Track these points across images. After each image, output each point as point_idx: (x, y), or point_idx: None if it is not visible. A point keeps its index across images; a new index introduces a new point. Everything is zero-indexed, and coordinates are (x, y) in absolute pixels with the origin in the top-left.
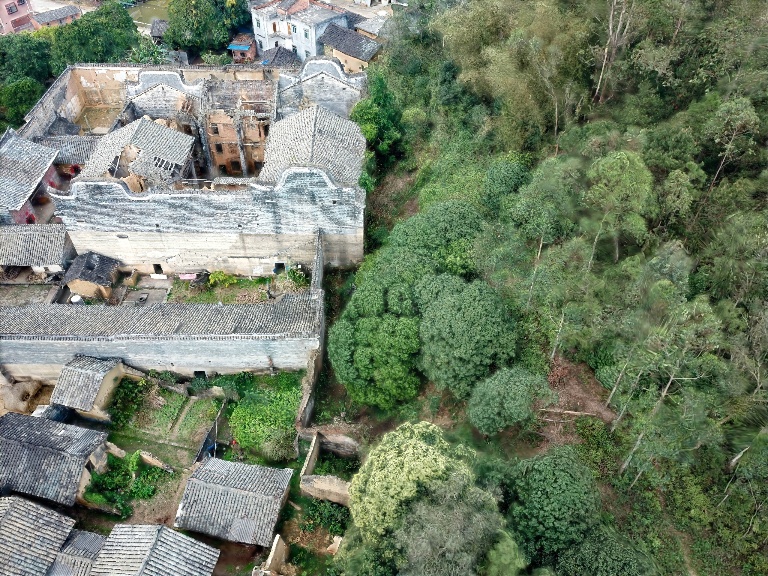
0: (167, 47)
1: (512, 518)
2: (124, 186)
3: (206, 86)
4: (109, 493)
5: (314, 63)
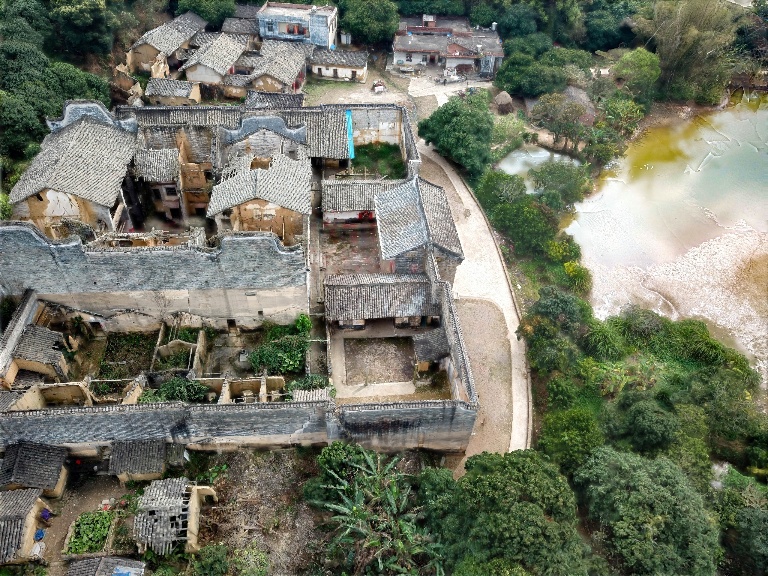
0: None
1: (47, 7)
2: None
3: None
4: None
5: None
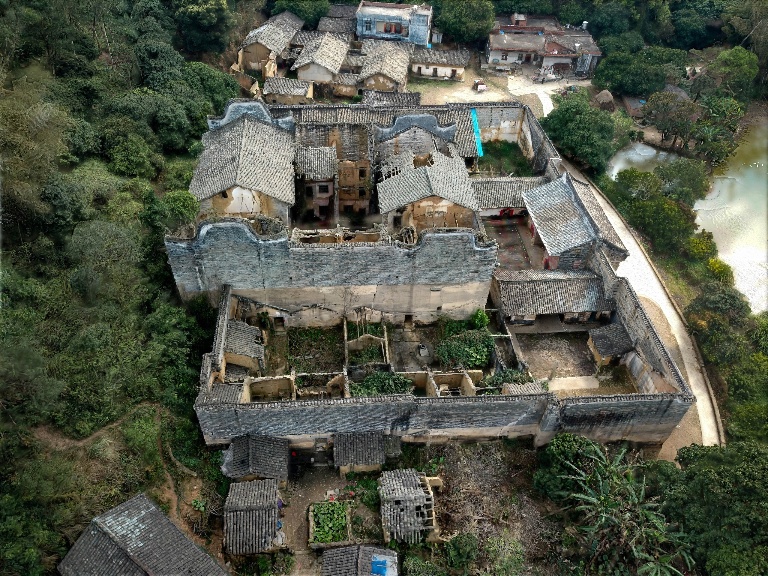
0: None
1: (169, 7)
2: None
3: None
4: None
5: None
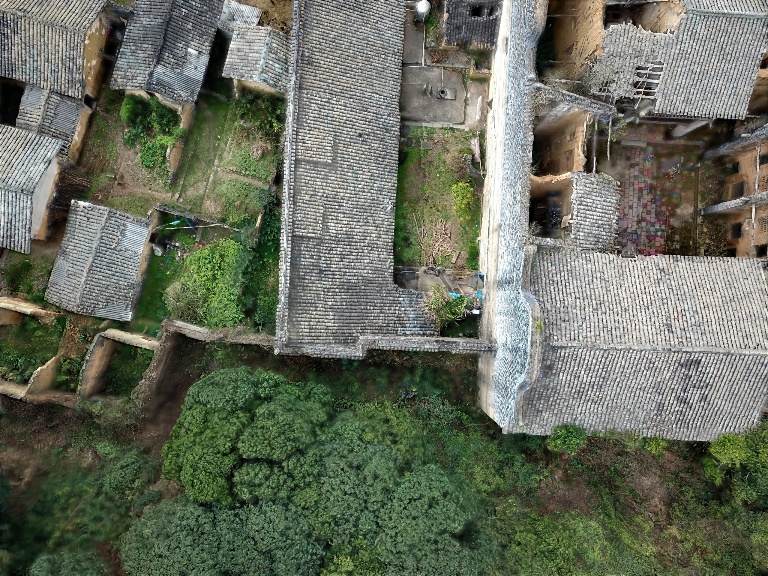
0: None
1: None
2: (535, 33)
3: None
4: (145, 120)
5: None
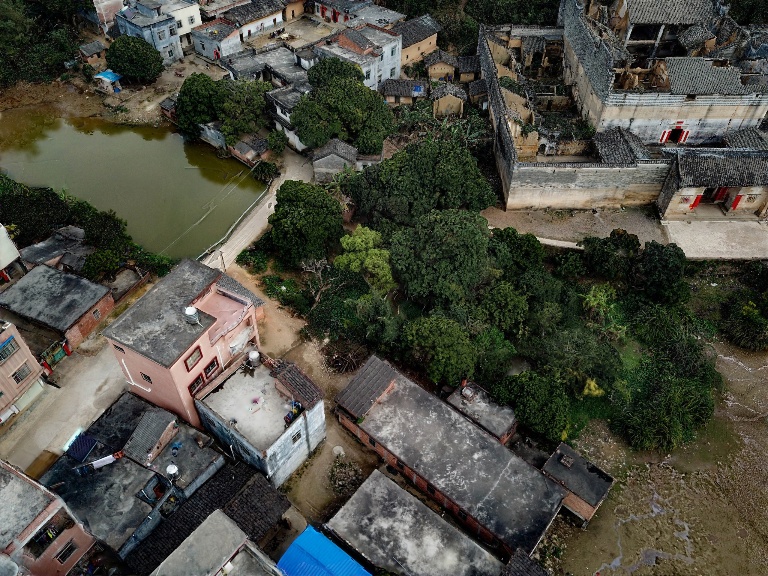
0: (373, 156)
1: None
2: None
3: None
4: None
5: None
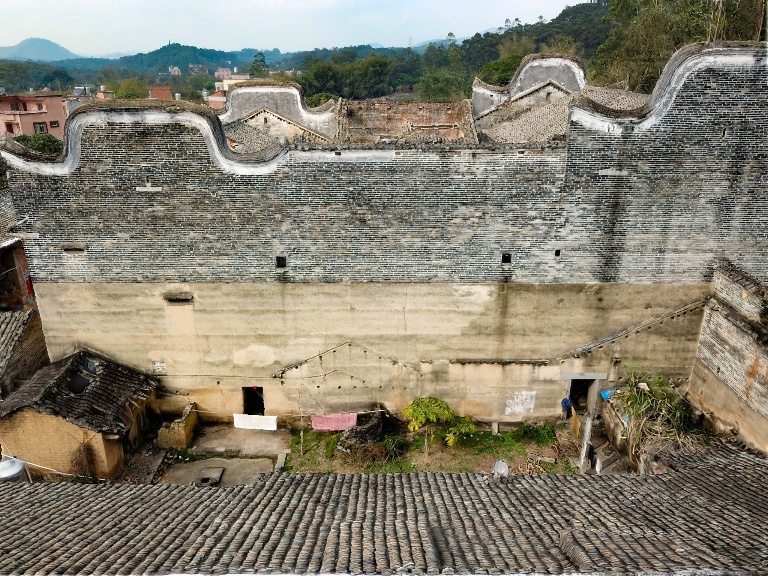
0: None
1: None
2: (215, 126)
3: (344, 108)
4: None
5: (538, 66)
